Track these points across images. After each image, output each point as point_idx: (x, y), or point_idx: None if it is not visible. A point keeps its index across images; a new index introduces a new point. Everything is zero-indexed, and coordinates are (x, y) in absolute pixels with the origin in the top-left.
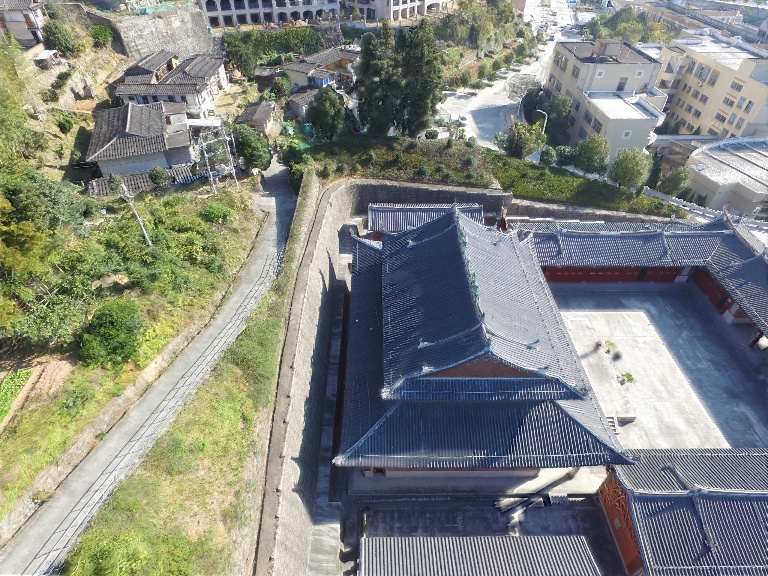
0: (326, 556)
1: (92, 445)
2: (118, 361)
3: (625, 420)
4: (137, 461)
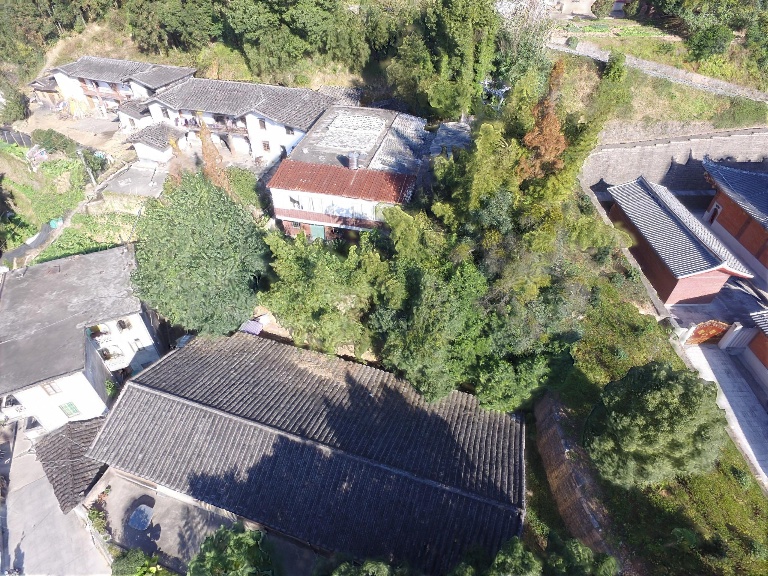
0: None
1: (649, 69)
2: (696, 52)
3: None
4: (654, 75)
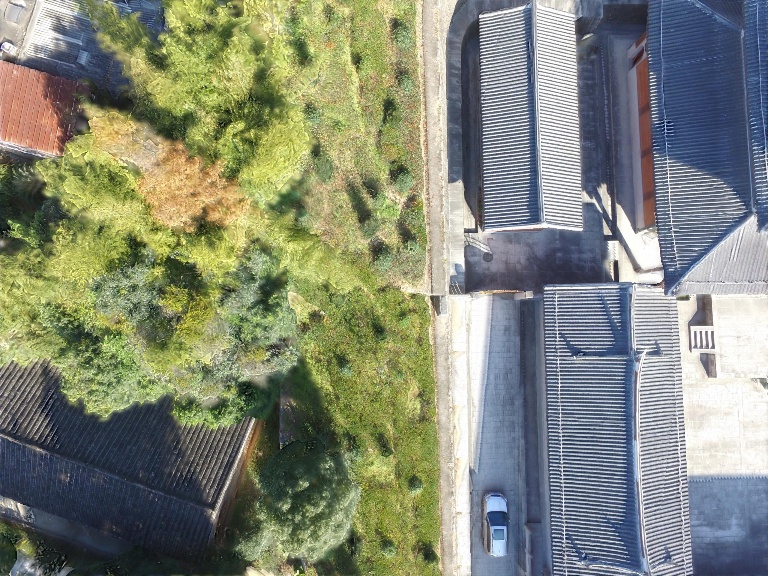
0: (554, 5)
1: None
2: None
3: (710, 366)
4: None
